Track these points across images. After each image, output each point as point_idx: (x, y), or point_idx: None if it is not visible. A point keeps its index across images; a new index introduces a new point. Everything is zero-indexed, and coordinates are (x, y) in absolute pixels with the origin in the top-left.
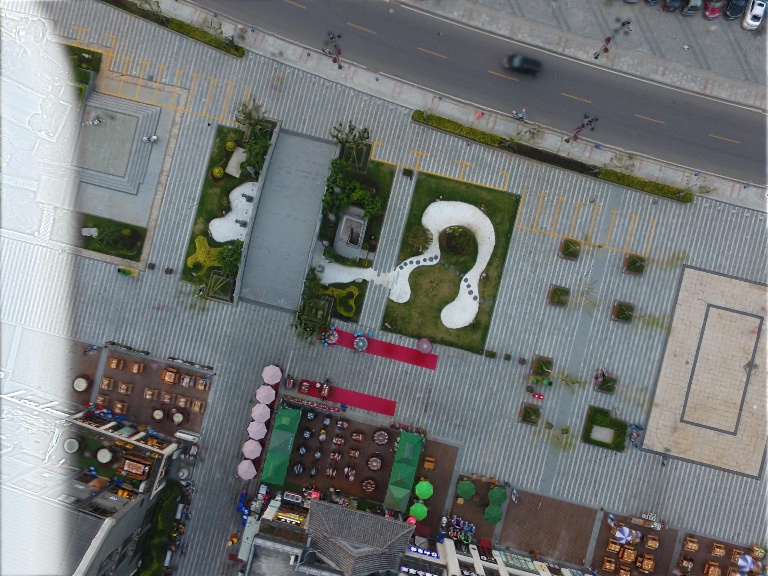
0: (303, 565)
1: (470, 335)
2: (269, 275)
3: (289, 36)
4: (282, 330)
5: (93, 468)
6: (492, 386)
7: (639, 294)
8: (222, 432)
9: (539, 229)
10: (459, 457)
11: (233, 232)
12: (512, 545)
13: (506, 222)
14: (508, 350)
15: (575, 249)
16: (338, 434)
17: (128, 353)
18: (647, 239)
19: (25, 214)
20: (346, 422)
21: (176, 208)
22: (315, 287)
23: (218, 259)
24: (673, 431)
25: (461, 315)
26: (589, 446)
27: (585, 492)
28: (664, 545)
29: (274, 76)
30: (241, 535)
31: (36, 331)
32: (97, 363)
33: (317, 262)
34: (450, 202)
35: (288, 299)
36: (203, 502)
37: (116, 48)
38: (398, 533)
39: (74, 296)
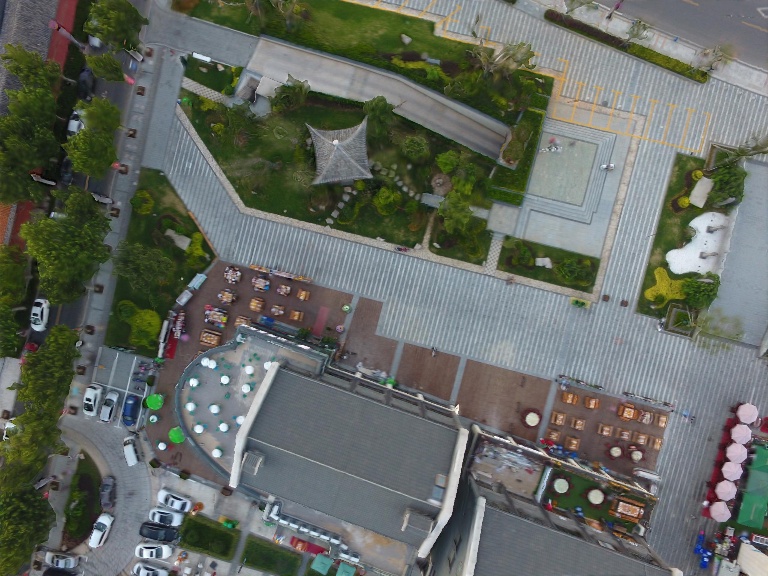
0: None
1: None
2: (735, 309)
3: (752, 61)
4: (743, 366)
5: (580, 509)
6: None
7: None
8: (678, 471)
9: None
10: None
11: (691, 264)
12: None
13: None
14: None
15: None
16: None
17: (579, 387)
18: None
19: None
20: None
21: (631, 238)
22: None
23: (680, 292)
24: None
25: None
26: None
27: None
28: None
29: (737, 103)
30: None
31: (481, 363)
32: (546, 397)
33: None
34: None
35: (751, 334)
36: (657, 543)
37: (569, 73)
38: None
39: (522, 328)
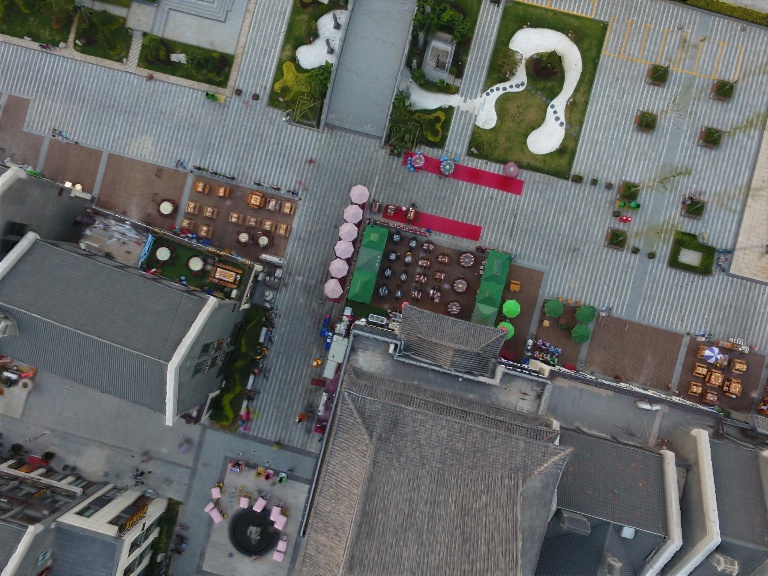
0: (401, 357)
1: (557, 160)
2: (356, 99)
3: None
4: (367, 156)
5: (184, 278)
6: (578, 211)
7: (727, 120)
8: (306, 257)
9: (626, 56)
10: (544, 281)
11: (320, 59)
12: (597, 370)
13: (594, 48)
14: (594, 175)
15: (664, 72)
16: (424, 256)
17: (213, 178)
18: (735, 66)
19: (115, 39)
20: (432, 244)
21: (264, 35)
22: (404, 107)
23: (305, 84)
24: (761, 256)
25: (547, 141)
26: (676, 271)
27: (671, 317)
28: (751, 371)
29: None
30: (324, 360)
31: (122, 157)
32: (182, 188)
33: (403, 89)
34: (537, 29)
35: (374, 125)
36: (286, 327)
37: None
38: (491, 337)
39: (161, 122)
